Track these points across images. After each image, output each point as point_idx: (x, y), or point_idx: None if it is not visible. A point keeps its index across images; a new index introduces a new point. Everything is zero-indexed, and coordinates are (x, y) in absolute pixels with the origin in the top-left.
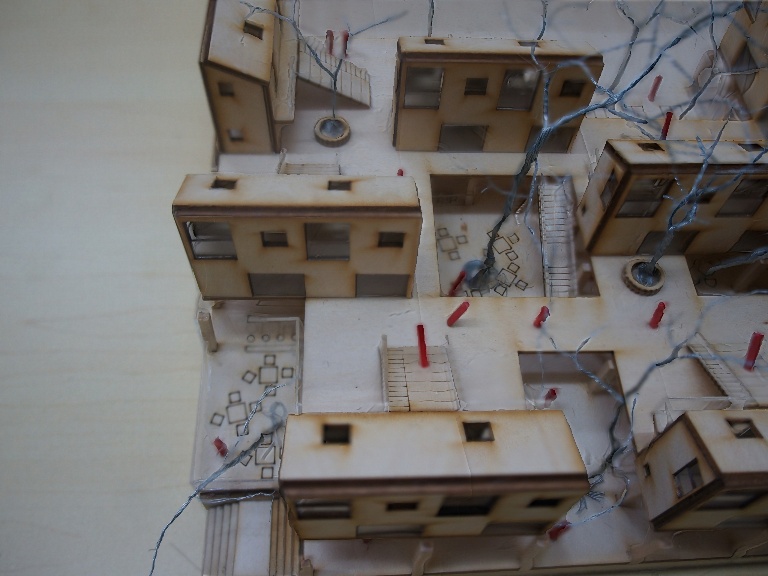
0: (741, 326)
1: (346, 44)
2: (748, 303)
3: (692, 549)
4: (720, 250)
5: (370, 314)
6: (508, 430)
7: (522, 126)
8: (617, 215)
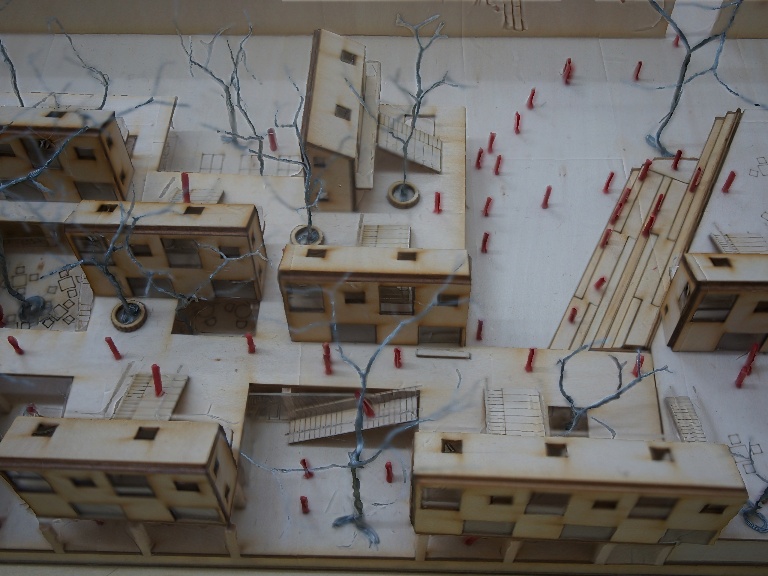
0: (194, 361)
1: None
2: (211, 342)
3: (108, 543)
4: (206, 295)
5: None
6: None
7: (64, 181)
8: (86, 263)
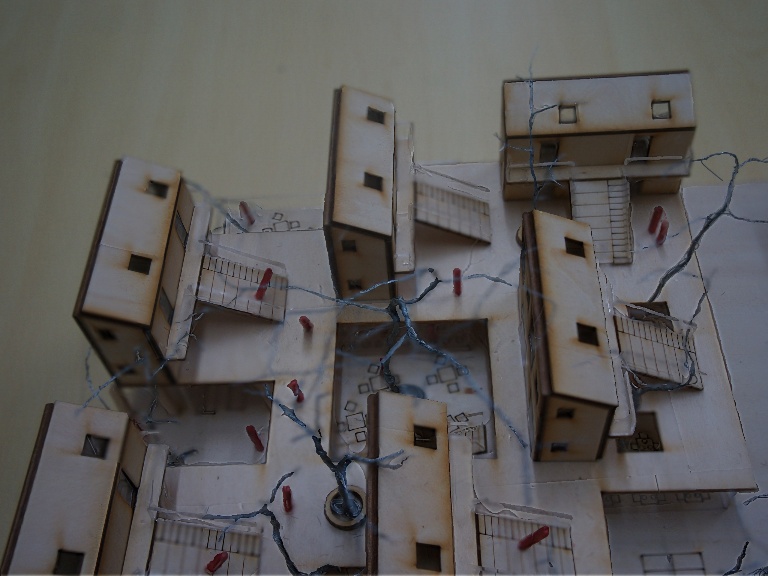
0: None
1: (661, 233)
2: None
3: None
4: None
5: (323, 272)
6: (136, 282)
7: None
8: None
